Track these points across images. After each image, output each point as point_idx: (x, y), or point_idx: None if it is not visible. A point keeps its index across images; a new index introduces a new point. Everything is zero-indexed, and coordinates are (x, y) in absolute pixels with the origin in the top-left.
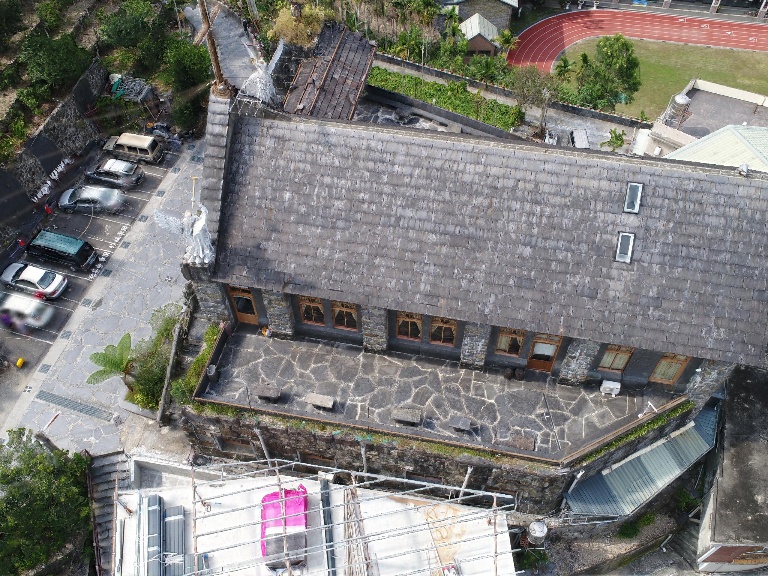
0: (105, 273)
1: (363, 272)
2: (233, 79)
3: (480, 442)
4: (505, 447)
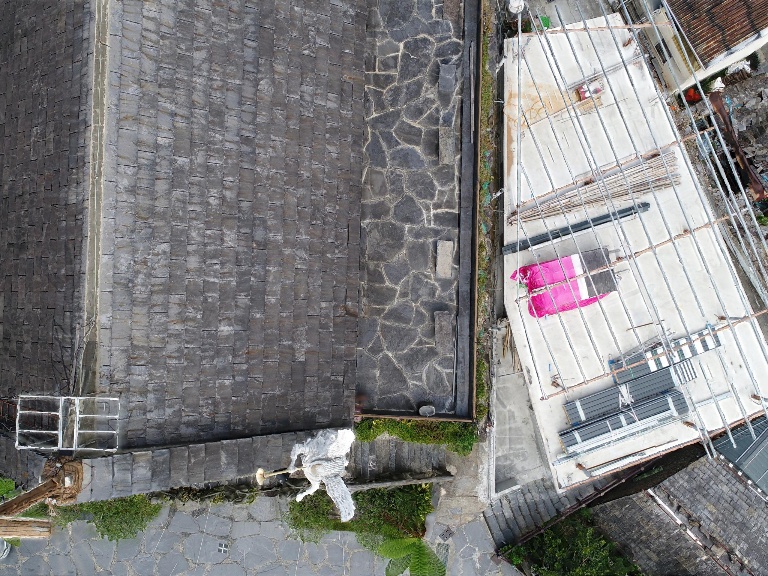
0: None
1: (322, 195)
2: None
3: (466, 53)
4: (467, 23)
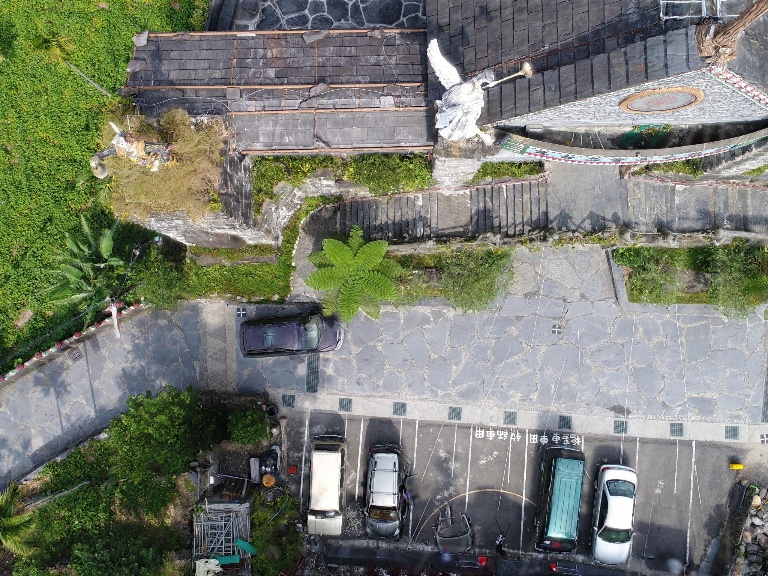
0: (566, 425)
1: None
2: (99, 396)
3: None
4: None
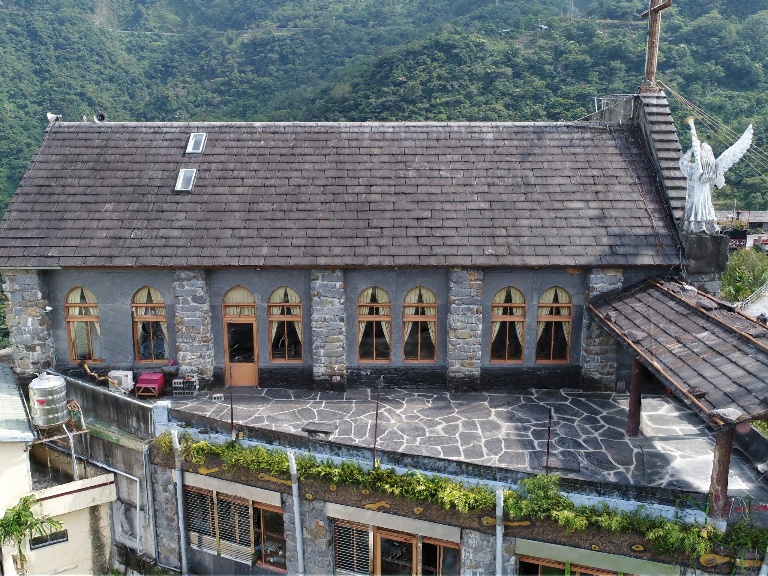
0: None
1: None
2: None
3: None
4: None
